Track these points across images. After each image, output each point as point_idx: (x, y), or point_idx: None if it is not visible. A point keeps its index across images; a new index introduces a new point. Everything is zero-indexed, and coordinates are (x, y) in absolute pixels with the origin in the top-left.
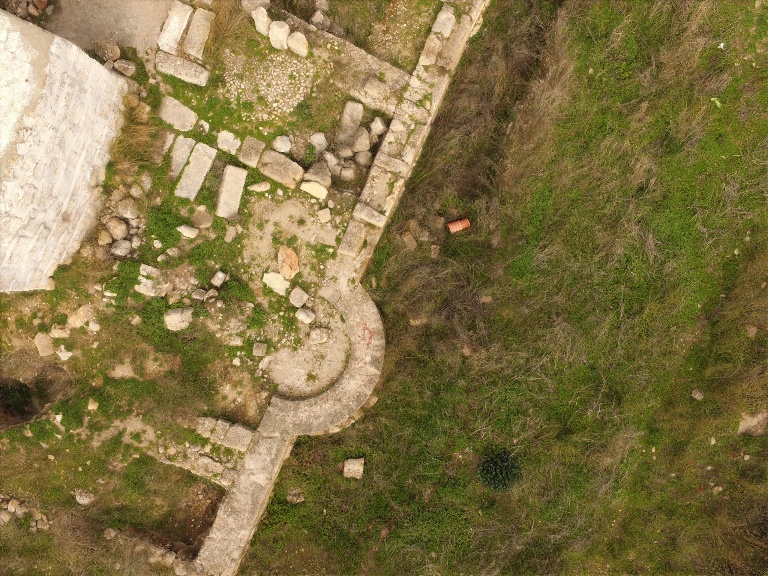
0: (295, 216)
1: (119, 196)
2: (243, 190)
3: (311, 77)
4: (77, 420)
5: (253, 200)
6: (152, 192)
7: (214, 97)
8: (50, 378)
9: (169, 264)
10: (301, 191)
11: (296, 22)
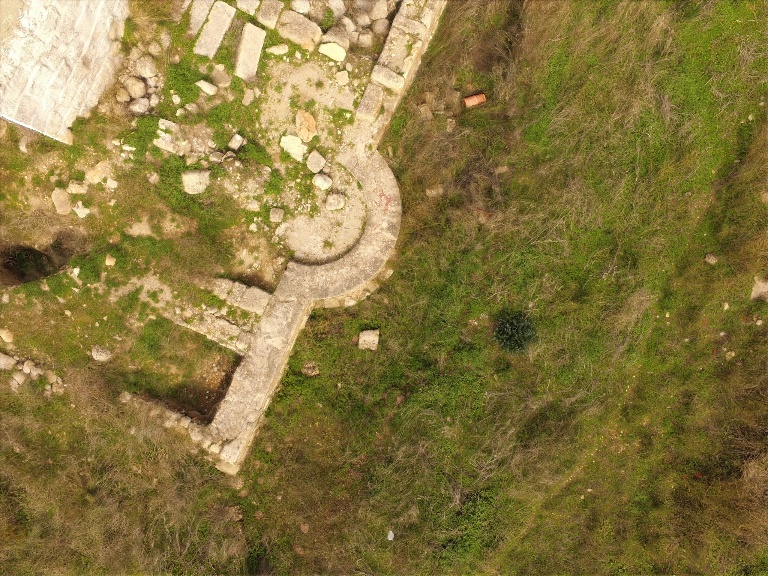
0: (313, 79)
1: (137, 54)
2: (261, 52)
3: None
4: (94, 274)
5: (271, 64)
6: (171, 49)
7: None
8: (65, 247)
9: (188, 119)
10: (319, 54)
11: None
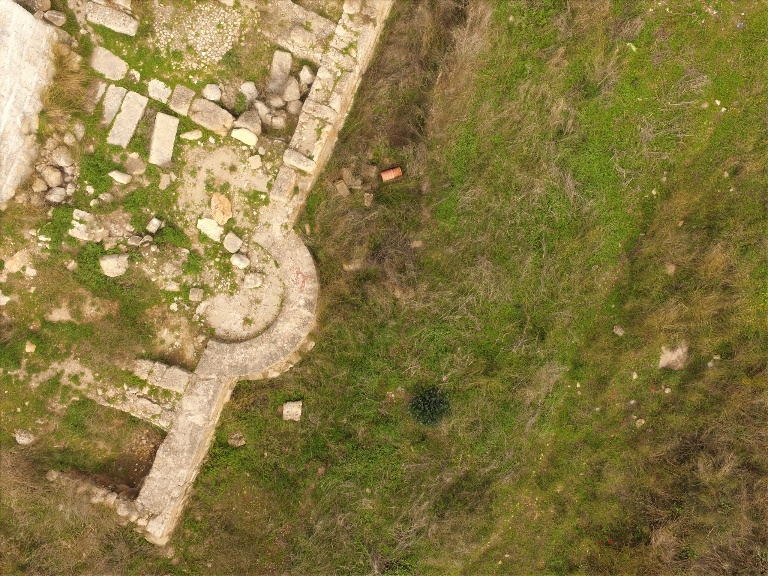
0: (227, 163)
1: (53, 145)
2: (175, 138)
3: (239, 26)
4: (14, 362)
5: (186, 148)
6: (85, 140)
7: (144, 47)
8: None
9: (102, 209)
10: (232, 139)
11: None
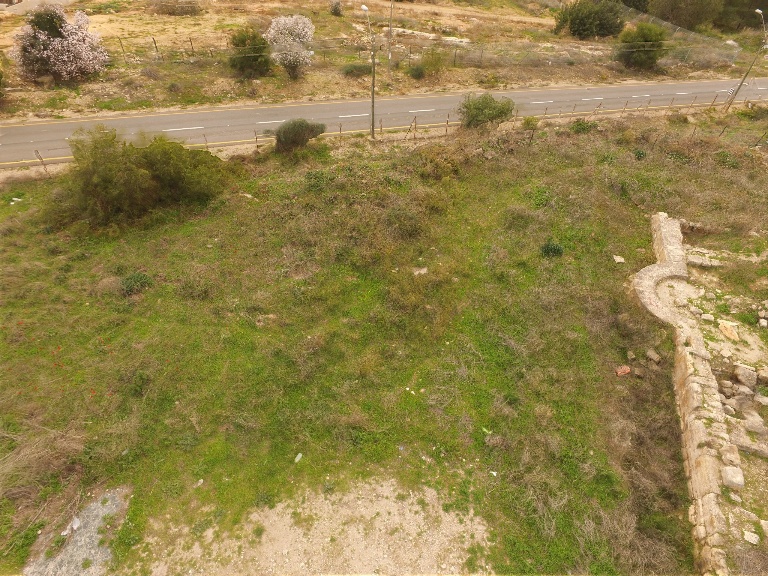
0: None
1: None
2: None
3: None
4: None
5: None
6: None
7: None
8: None
9: None
10: None
11: None
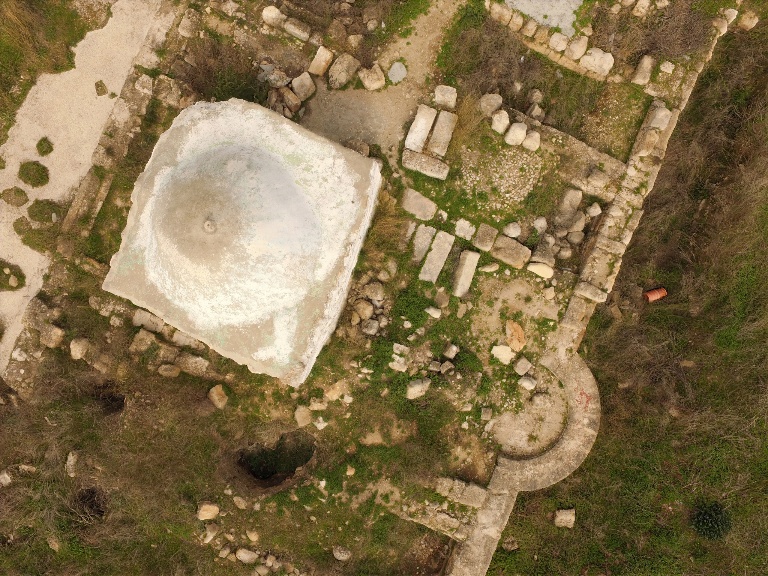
0: (522, 294)
1: (367, 280)
2: (475, 271)
3: (539, 169)
4: (339, 485)
5: (481, 279)
6: (398, 276)
7: (452, 189)
8: (288, 441)
9: (418, 343)
10: (527, 271)
11: (523, 118)
